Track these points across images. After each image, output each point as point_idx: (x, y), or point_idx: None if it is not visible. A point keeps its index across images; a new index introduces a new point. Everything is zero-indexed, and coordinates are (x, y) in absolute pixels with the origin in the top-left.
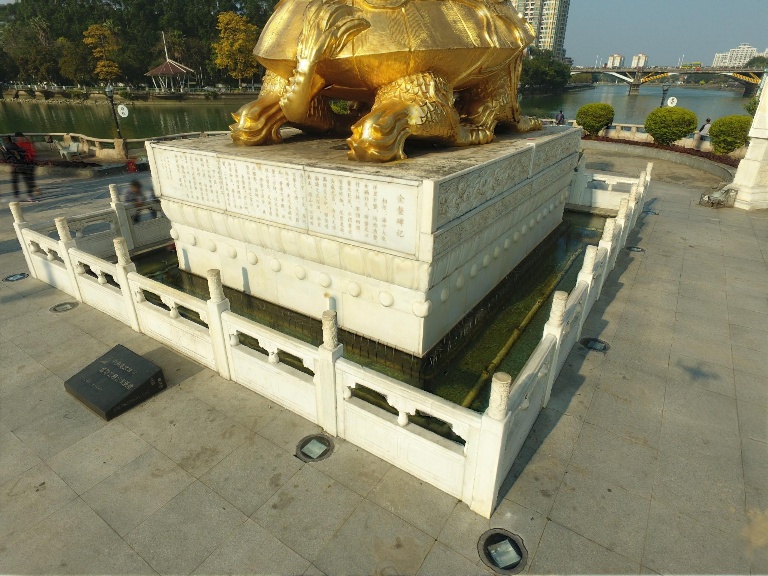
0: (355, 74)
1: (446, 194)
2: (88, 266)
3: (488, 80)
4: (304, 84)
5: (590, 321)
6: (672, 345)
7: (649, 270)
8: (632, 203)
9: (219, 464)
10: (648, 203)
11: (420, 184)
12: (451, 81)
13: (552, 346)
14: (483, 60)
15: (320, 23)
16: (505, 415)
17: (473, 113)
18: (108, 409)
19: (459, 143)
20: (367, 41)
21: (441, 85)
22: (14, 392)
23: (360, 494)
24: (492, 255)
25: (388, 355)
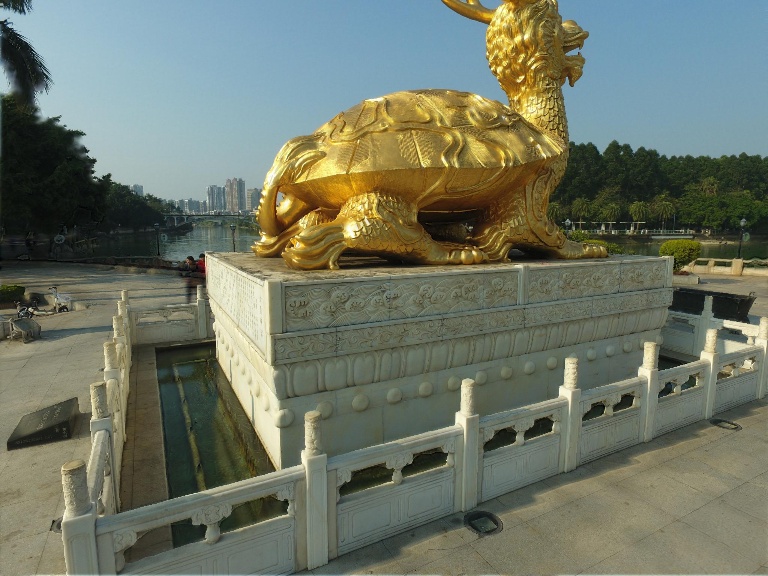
0: (315, 196)
1: (302, 298)
2: (162, 345)
3: (499, 202)
4: (265, 204)
5: (518, 493)
6: (602, 561)
7: (709, 454)
8: (709, 355)
9: (6, 506)
10: None
11: (263, 284)
12: (412, 201)
13: (291, 478)
14: (442, 180)
15: (284, 157)
16: (76, 514)
17: (477, 235)
18: (11, 440)
19: (431, 261)
20: (318, 168)
21: (389, 203)
22: (2, 416)
23: (36, 575)
24: (444, 385)
25: (268, 467)
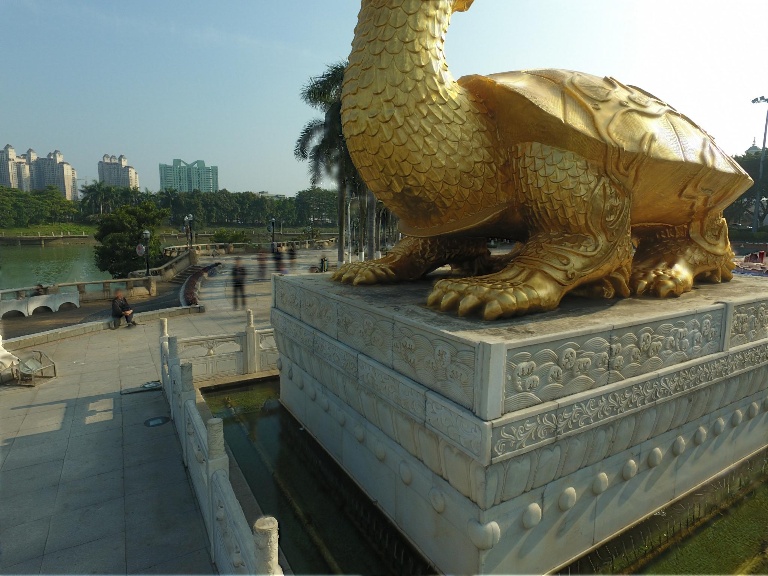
0: None
1: None
2: None
3: None
4: None
5: None
6: None
7: None
8: None
9: None
10: (79, 399)
11: None
12: None
13: None
14: None
15: None
16: None
17: None
18: None
19: None
20: None
21: None
22: None
23: None
24: None
25: None
